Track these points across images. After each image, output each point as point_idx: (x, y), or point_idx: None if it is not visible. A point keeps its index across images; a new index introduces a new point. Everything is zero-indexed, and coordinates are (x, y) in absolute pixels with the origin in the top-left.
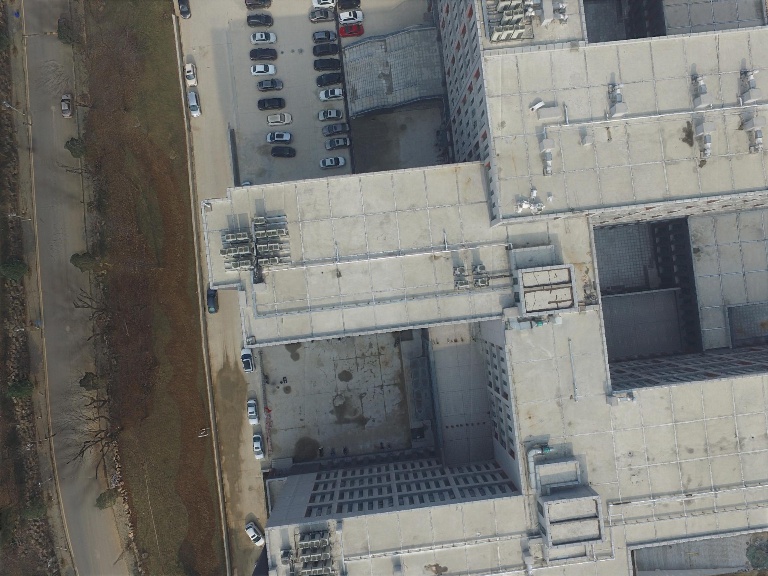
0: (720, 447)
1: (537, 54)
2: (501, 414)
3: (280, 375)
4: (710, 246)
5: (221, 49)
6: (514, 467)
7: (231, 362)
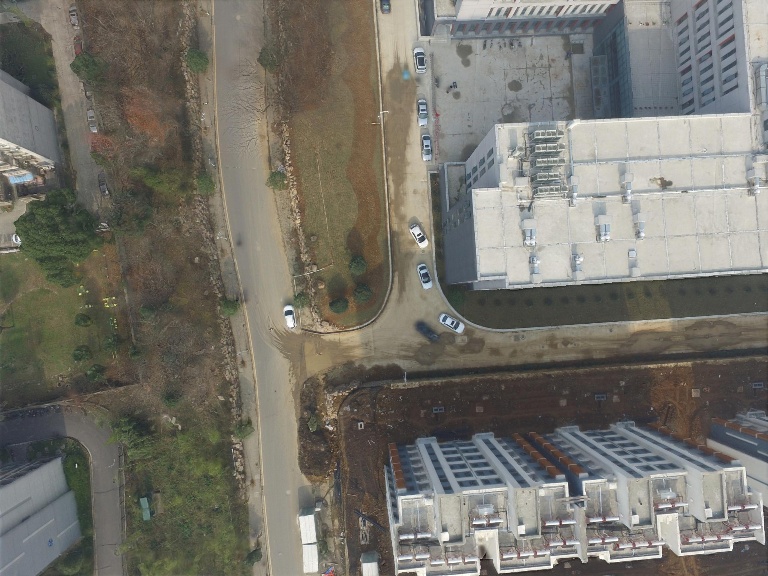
0: None
1: None
2: (705, 74)
3: (450, 80)
4: None
5: None
6: (735, 96)
7: (401, 63)
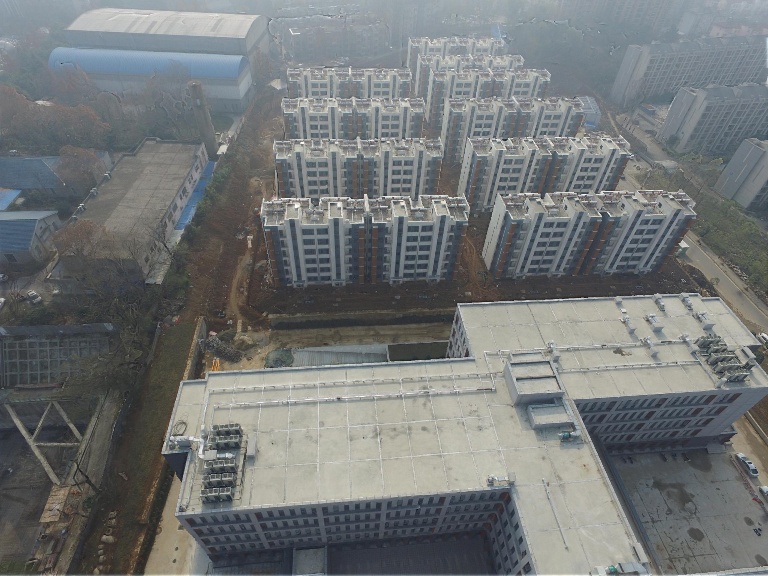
0: (396, 431)
1: None
2: None
3: (765, 539)
4: None
5: None
6: None
7: None
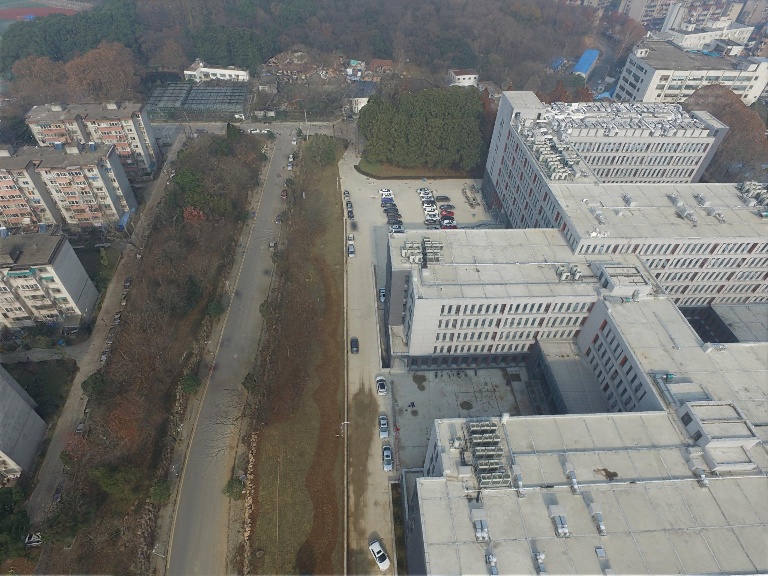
0: None
1: (577, 185)
2: (620, 388)
3: (408, 401)
4: (738, 323)
5: (370, 232)
6: (648, 400)
7: (366, 388)
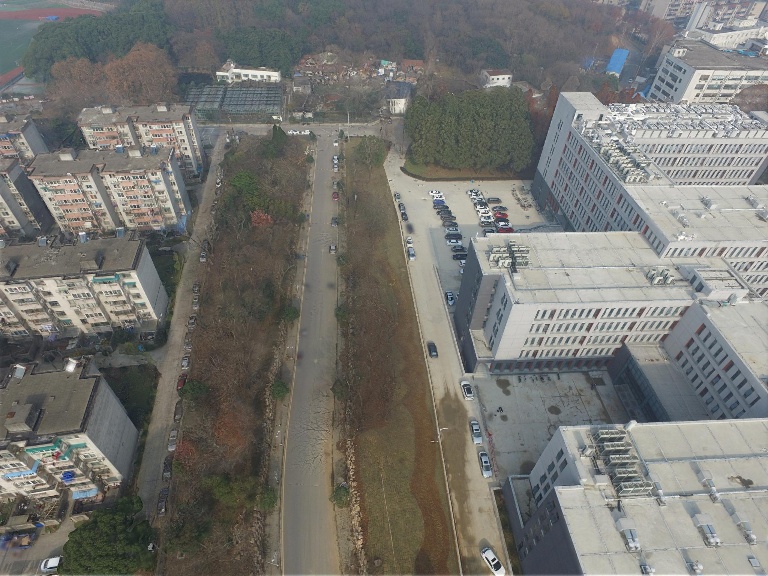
0: None
1: (652, 188)
2: (723, 392)
3: (496, 406)
4: None
5: (427, 235)
6: (763, 406)
7: (451, 393)
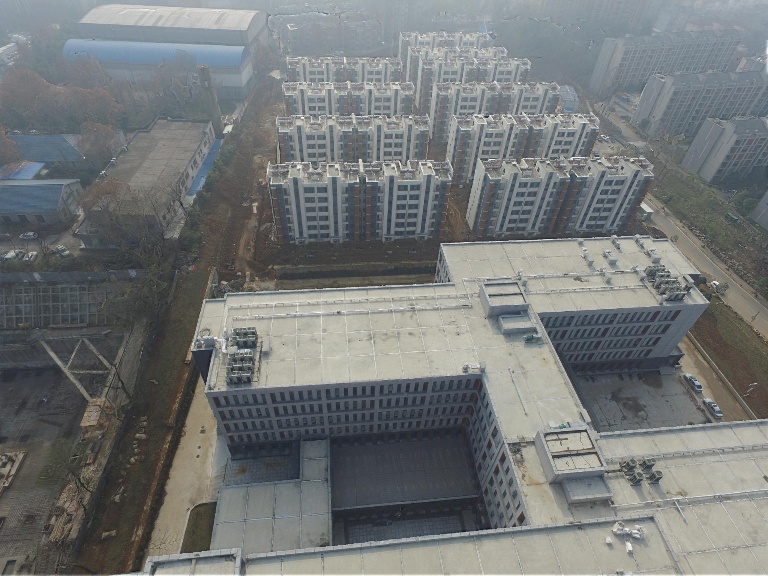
0: (387, 335)
1: None
2: None
3: None
4: None
5: None
6: None
7: None
